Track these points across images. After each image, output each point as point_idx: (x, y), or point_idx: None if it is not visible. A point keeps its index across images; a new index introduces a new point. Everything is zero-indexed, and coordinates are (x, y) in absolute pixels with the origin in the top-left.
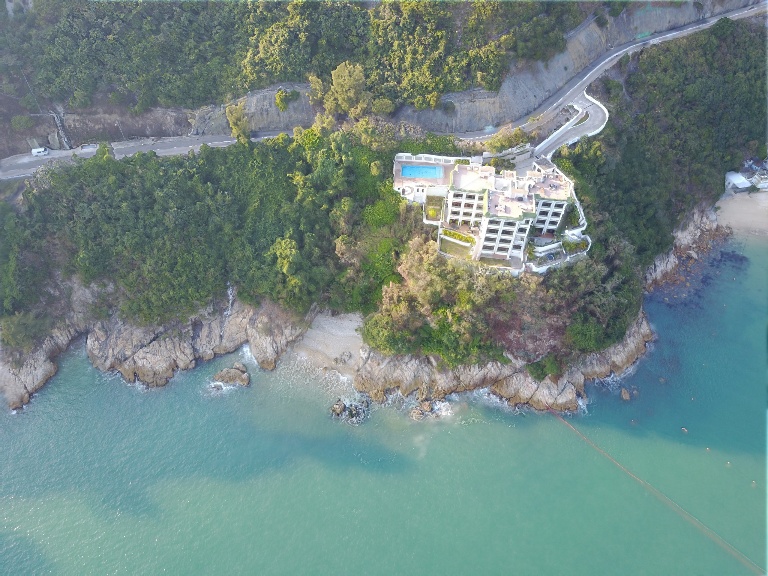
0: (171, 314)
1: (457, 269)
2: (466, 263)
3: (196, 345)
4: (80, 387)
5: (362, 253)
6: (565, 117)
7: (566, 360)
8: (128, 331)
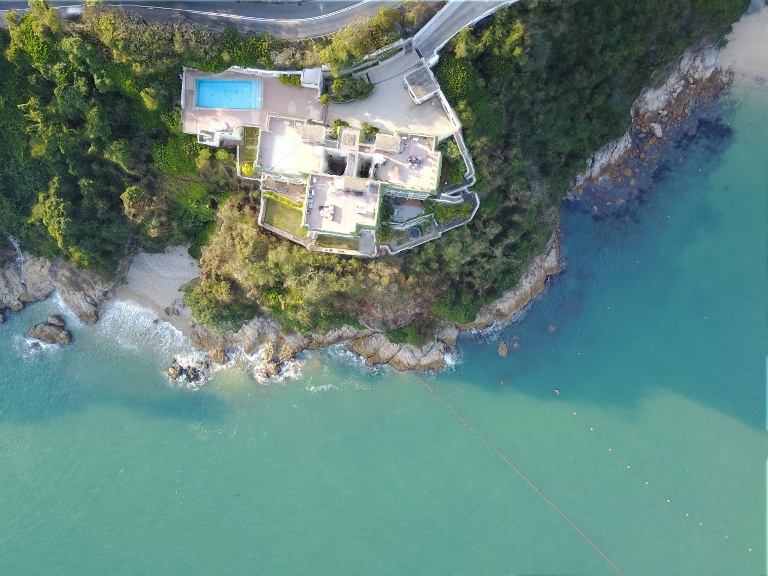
0: None
1: (281, 264)
2: (292, 259)
3: None
4: None
5: (169, 197)
6: None
7: None
8: None
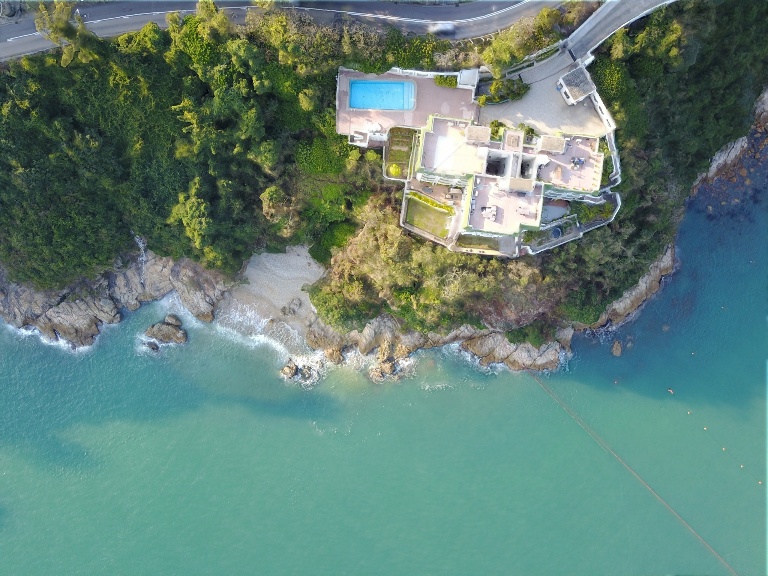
0: (71, 277)
1: (424, 264)
2: (437, 260)
3: (115, 295)
4: None
5: (302, 197)
6: None
7: (554, 330)
8: (27, 293)
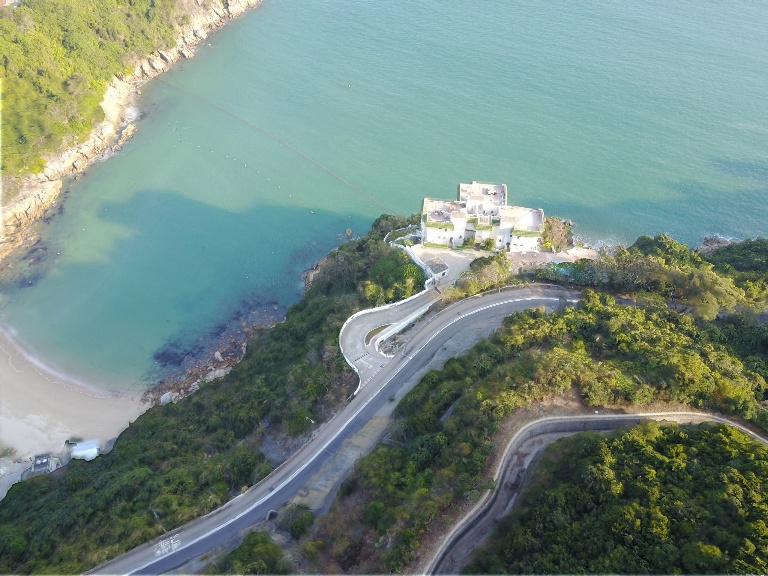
0: None
1: None
2: None
3: None
4: (766, 236)
5: None
6: (398, 341)
7: None
8: None
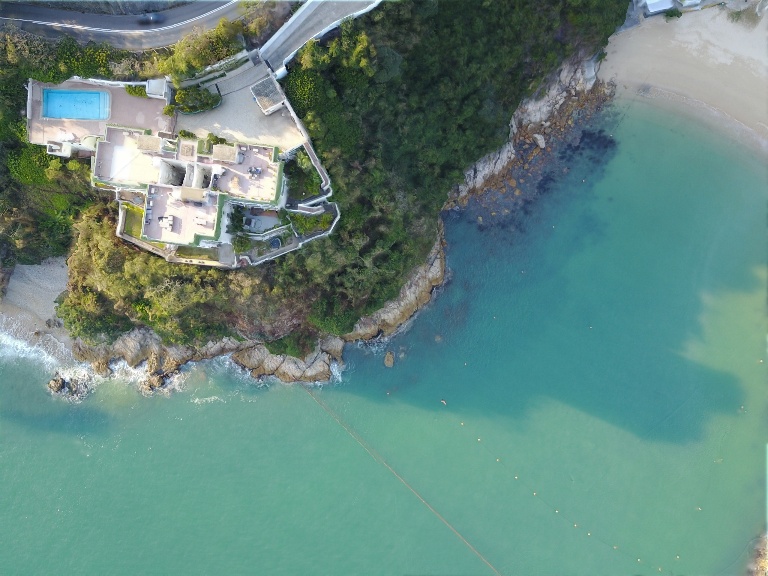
0: None
1: (138, 275)
2: (147, 270)
3: None
4: None
5: (35, 208)
6: None
7: None
8: None
